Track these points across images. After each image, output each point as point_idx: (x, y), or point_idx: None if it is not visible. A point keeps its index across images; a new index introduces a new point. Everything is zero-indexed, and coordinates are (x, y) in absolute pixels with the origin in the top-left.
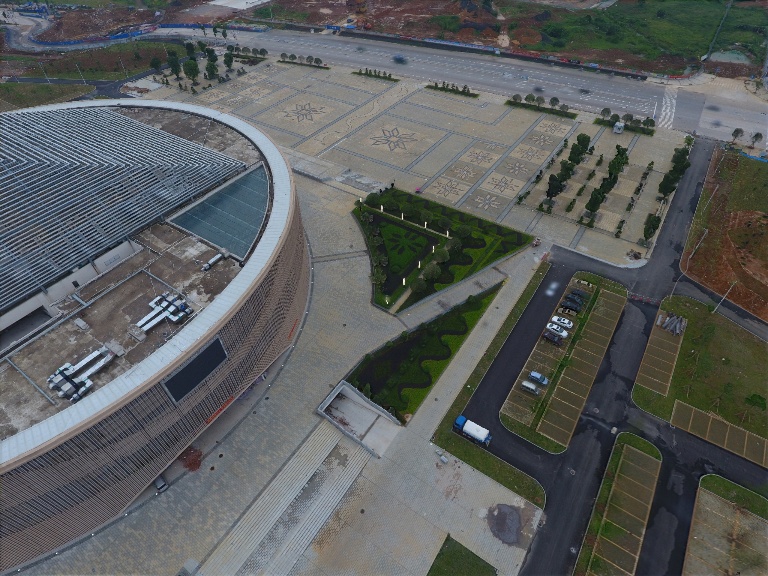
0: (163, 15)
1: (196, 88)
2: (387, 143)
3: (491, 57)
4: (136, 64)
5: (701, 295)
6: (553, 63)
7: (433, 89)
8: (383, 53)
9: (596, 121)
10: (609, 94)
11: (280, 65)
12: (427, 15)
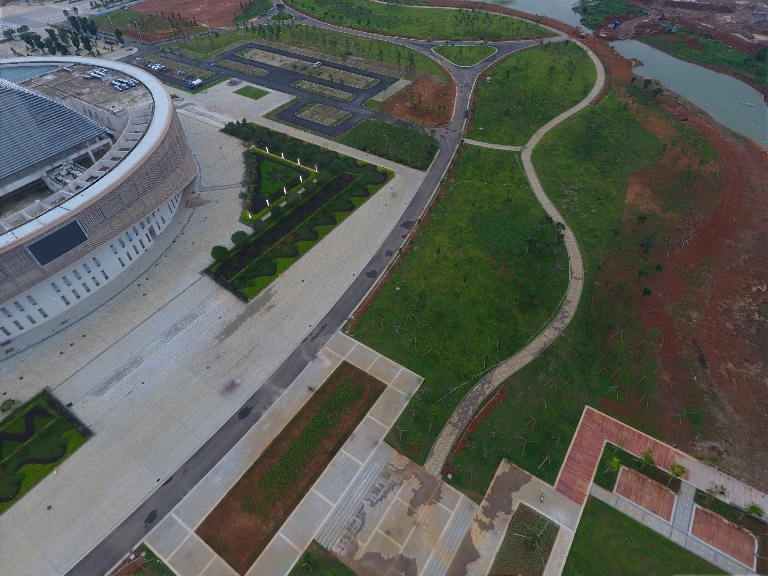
0: None
1: None
2: None
3: None
4: None
5: (165, 42)
6: None
7: None
8: None
9: None
10: None
11: None
12: None
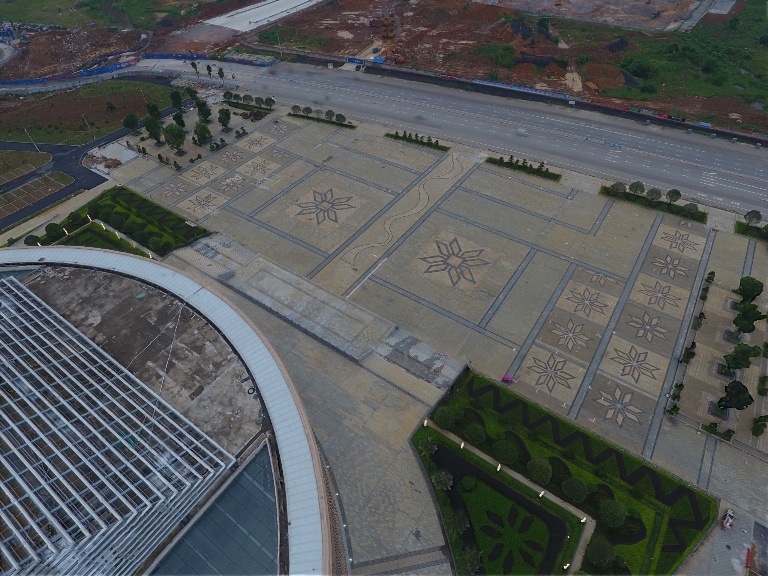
0: (150, 39)
1: (181, 160)
2: (446, 269)
3: (563, 109)
4: (107, 119)
5: None
6: (649, 121)
7: (496, 165)
8: (423, 103)
9: (738, 228)
10: (740, 176)
11: (291, 121)
12: (470, 41)
